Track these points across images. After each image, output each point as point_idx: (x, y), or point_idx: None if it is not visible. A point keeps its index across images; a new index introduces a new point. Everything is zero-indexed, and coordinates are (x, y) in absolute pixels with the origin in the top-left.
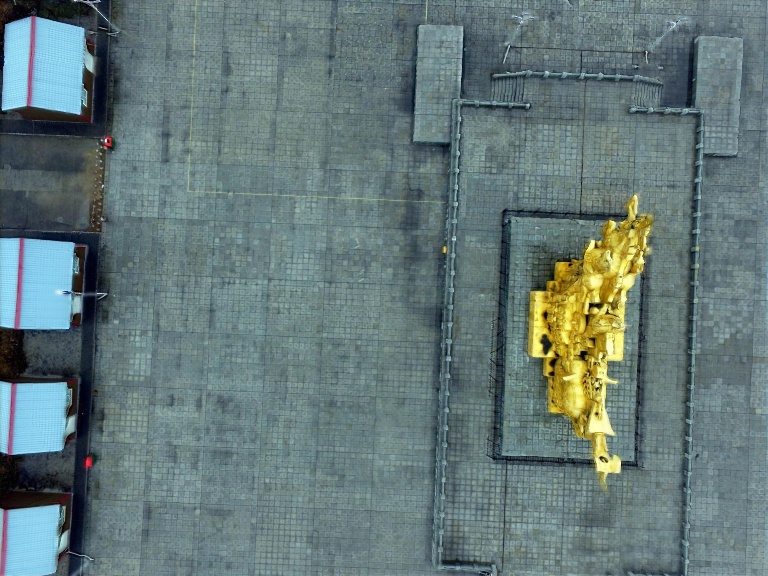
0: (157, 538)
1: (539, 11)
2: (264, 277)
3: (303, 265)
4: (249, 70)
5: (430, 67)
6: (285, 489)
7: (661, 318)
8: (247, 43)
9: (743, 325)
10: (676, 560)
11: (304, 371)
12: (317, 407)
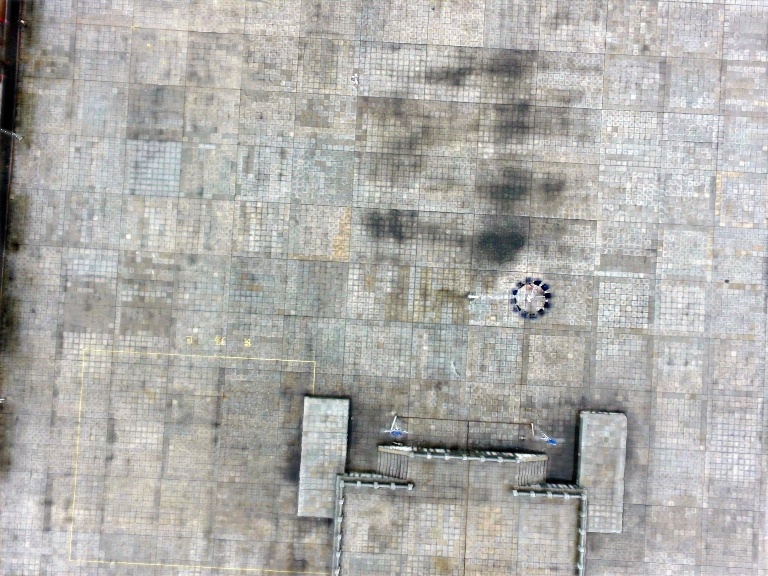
0: None
1: (426, 381)
2: None
3: None
4: (135, 437)
5: (315, 441)
6: None
7: None
8: (133, 410)
9: None
10: None
11: None
12: None
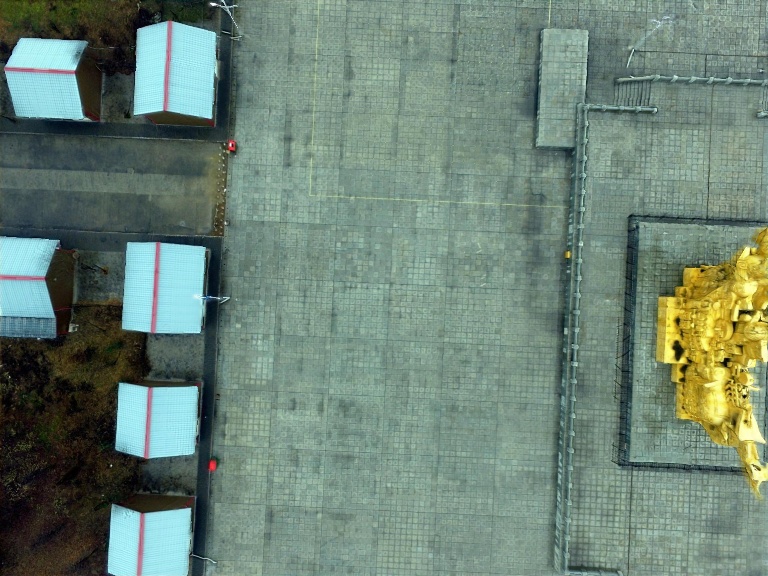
0: (279, 542)
1: (663, 15)
2: (386, 281)
3: (425, 270)
4: (371, 74)
5: (555, 71)
6: (407, 494)
7: None
8: (369, 47)
9: None
10: None
11: (426, 376)
12: (439, 412)
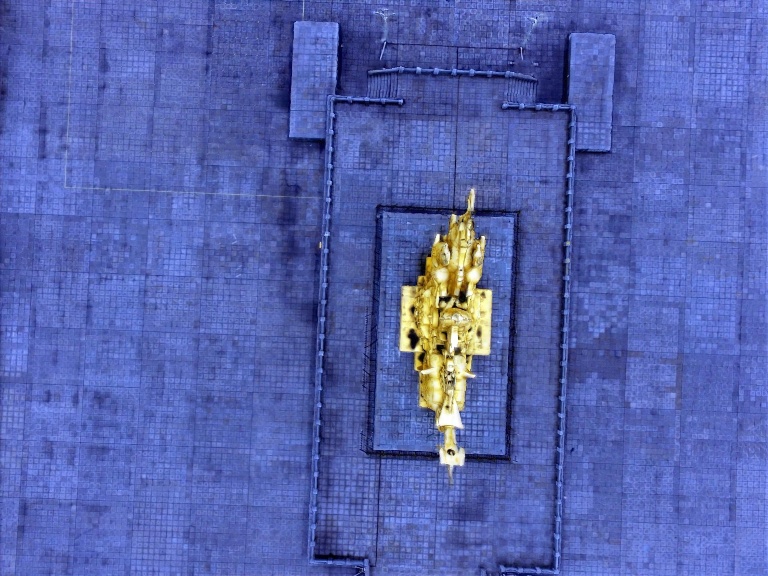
0: (33, 534)
1: (415, 8)
2: (141, 273)
3: (180, 261)
4: (126, 66)
5: (305, 63)
6: (162, 485)
7: (534, 313)
8: (124, 39)
9: (618, 319)
10: (548, 553)
11: (181, 367)
12: (194, 402)
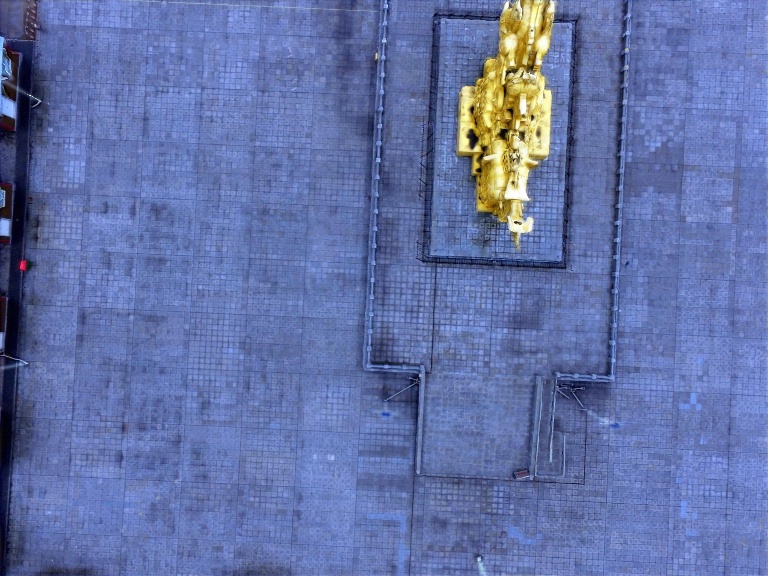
0: (91, 343)
1: None
2: (197, 86)
3: (236, 74)
4: None
5: None
6: (218, 296)
7: (591, 122)
8: None
9: (674, 133)
10: (603, 362)
11: (237, 179)
12: (250, 215)
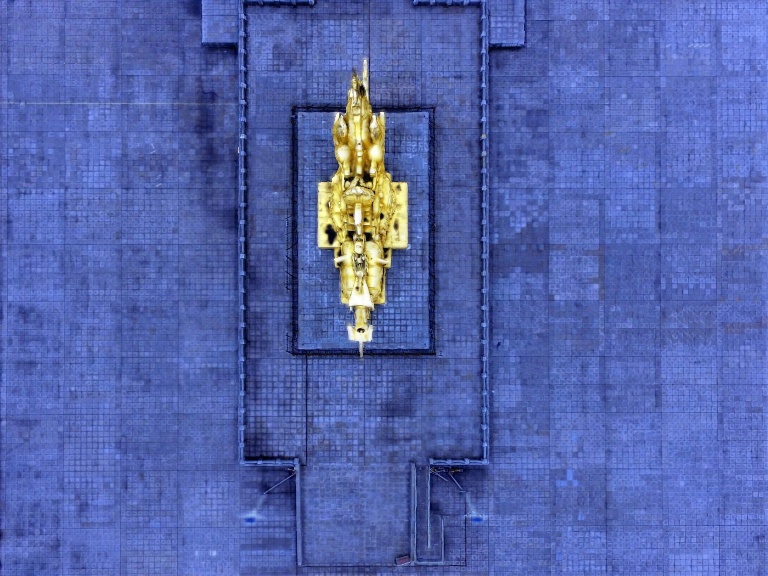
0: None
1: None
2: (60, 186)
3: (99, 172)
4: None
5: None
6: (91, 396)
7: (454, 208)
8: None
9: (539, 213)
10: (477, 445)
11: (105, 278)
12: (120, 314)
